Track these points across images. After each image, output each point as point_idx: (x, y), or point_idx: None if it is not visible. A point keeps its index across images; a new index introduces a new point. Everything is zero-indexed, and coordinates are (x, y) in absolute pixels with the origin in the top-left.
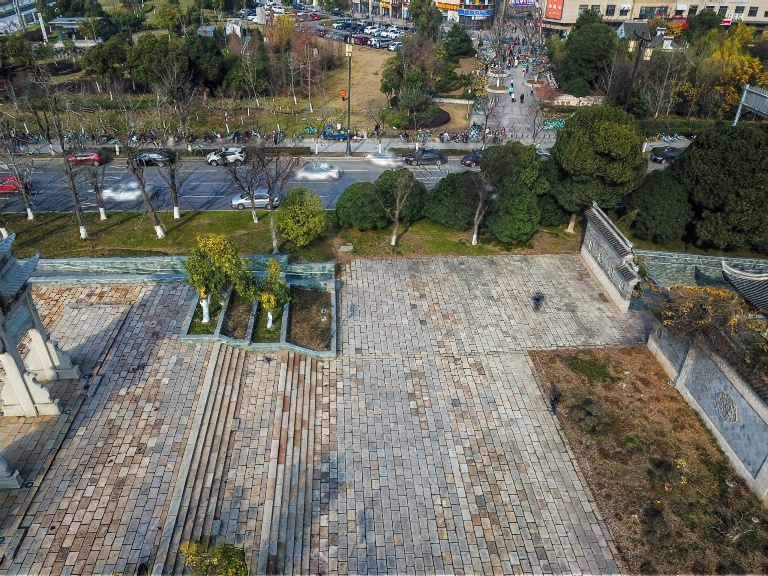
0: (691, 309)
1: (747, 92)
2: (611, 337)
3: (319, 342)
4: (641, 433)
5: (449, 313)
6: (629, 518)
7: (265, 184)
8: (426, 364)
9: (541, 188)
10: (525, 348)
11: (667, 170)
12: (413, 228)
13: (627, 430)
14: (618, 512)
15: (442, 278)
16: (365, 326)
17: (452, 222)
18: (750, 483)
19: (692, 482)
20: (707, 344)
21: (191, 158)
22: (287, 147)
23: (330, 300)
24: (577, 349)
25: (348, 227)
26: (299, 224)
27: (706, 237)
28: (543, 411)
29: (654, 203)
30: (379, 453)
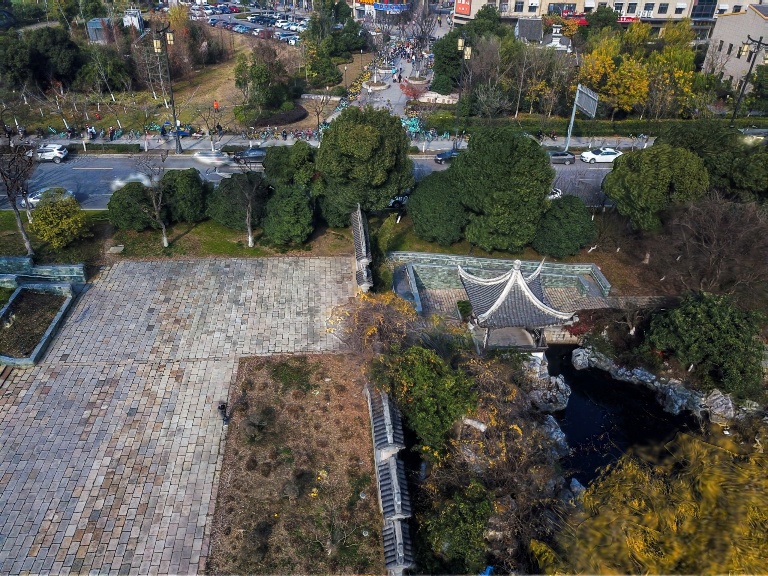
0: (348, 317)
1: (579, 92)
2: (334, 343)
3: (21, 349)
4: (302, 443)
5: (183, 318)
6: (234, 533)
7: (73, 182)
8: (126, 371)
9: (317, 189)
10: (239, 354)
11: (445, 172)
12: (197, 229)
13: (290, 440)
14: (230, 526)
15: (198, 281)
16: (87, 331)
17: (233, 223)
18: (378, 495)
19: (324, 494)
20: (357, 353)
21: (13, 155)
22: (116, 144)
23: (62, 304)
24: (292, 355)
25: (125, 228)
26: (52, 225)
27: (473, 240)
28: (217, 420)
29: (426, 205)
30: (19, 465)
